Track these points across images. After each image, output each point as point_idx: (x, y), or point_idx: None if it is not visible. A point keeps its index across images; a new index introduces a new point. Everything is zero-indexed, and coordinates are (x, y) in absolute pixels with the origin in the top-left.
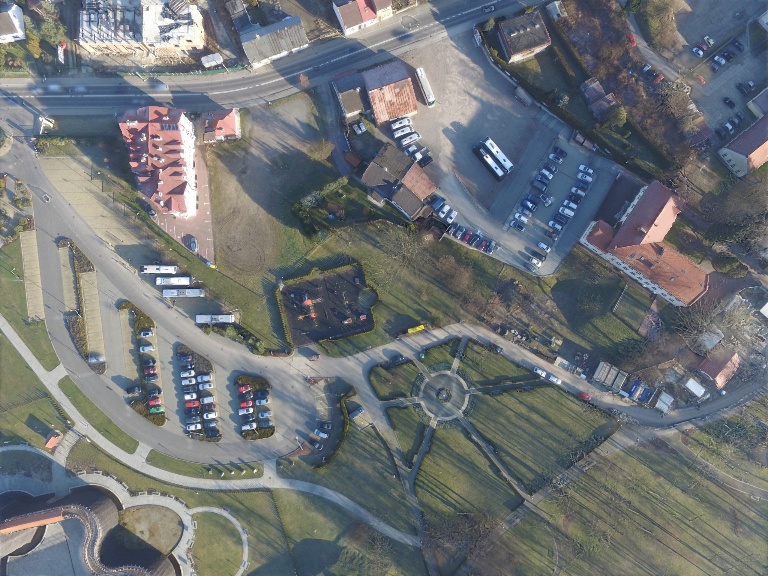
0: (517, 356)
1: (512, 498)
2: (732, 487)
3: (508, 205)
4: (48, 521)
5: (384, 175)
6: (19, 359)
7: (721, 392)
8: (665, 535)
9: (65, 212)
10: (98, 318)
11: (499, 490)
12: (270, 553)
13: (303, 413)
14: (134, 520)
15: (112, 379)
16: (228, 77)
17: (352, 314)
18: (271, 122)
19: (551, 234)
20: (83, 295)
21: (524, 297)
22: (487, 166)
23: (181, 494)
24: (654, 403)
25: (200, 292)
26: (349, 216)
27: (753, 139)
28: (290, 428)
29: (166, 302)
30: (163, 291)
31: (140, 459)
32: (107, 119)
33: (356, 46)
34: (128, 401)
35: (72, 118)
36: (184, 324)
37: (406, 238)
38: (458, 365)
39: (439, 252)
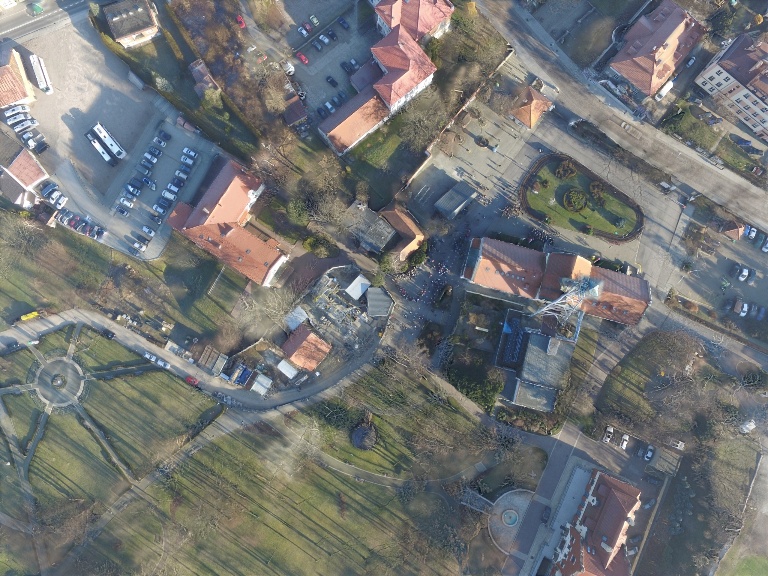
0: (130, 341)
1: (120, 483)
2: (337, 469)
3: (117, 190)
4: None
5: None
6: None
7: (315, 373)
8: (272, 519)
9: None
10: None
11: (109, 476)
12: None
13: None
14: None
15: None
16: None
17: None
18: None
19: (153, 218)
20: None
21: (134, 282)
22: None
23: None
24: (249, 385)
25: None
26: None
27: (339, 117)
28: None
29: None
30: None
31: None
32: None
33: None
34: None
35: None
36: None
37: (23, 225)
38: (73, 351)
39: (55, 238)
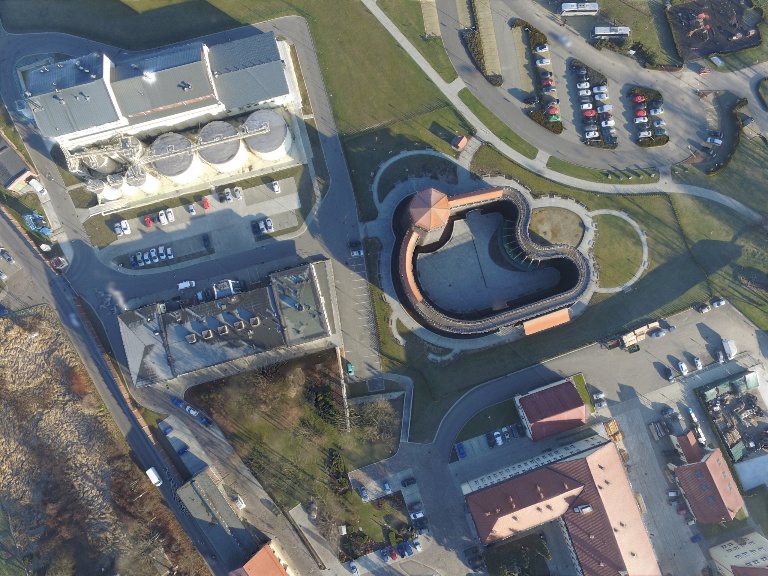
0: None
1: None
2: None
3: None
4: (489, 196)
5: None
6: (419, 72)
7: None
8: None
9: None
10: (492, 35)
11: None
12: (669, 253)
13: (694, 124)
14: (537, 221)
15: (509, 91)
16: None
17: (737, 32)
18: None
19: None
20: (477, 14)
21: None
22: None
23: (582, 197)
24: None
25: None
26: None
27: None
28: (682, 138)
29: (557, 21)
30: (562, 5)
31: (541, 164)
32: None
33: None
34: (525, 112)
35: None
36: (576, 41)
37: None
38: None
39: None
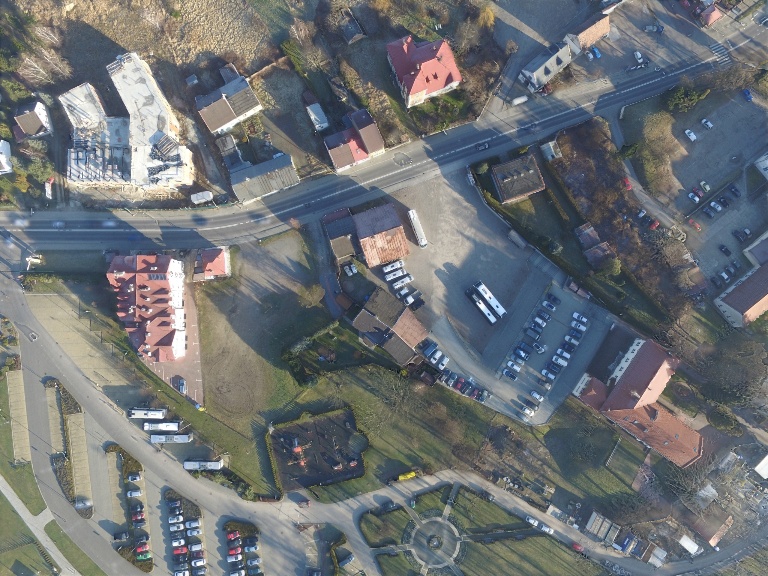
0: (509, 504)
1: None
2: None
3: (501, 352)
4: None
5: (375, 323)
6: (5, 503)
7: (715, 548)
8: None
9: (52, 351)
10: (85, 461)
11: None
12: None
13: (292, 559)
14: None
15: (99, 524)
16: (218, 213)
17: (342, 459)
18: (261, 260)
19: (544, 384)
20: (70, 437)
21: (516, 445)
22: (480, 311)
23: None
24: (647, 559)
25: (188, 438)
26: (340, 358)
27: (749, 294)
28: (279, 575)
29: (154, 445)
30: (151, 437)
31: None
32: (95, 254)
33: (348, 183)
34: (115, 546)
35: (60, 253)
36: (172, 467)
37: (397, 382)
38: (449, 512)
39: (431, 396)
